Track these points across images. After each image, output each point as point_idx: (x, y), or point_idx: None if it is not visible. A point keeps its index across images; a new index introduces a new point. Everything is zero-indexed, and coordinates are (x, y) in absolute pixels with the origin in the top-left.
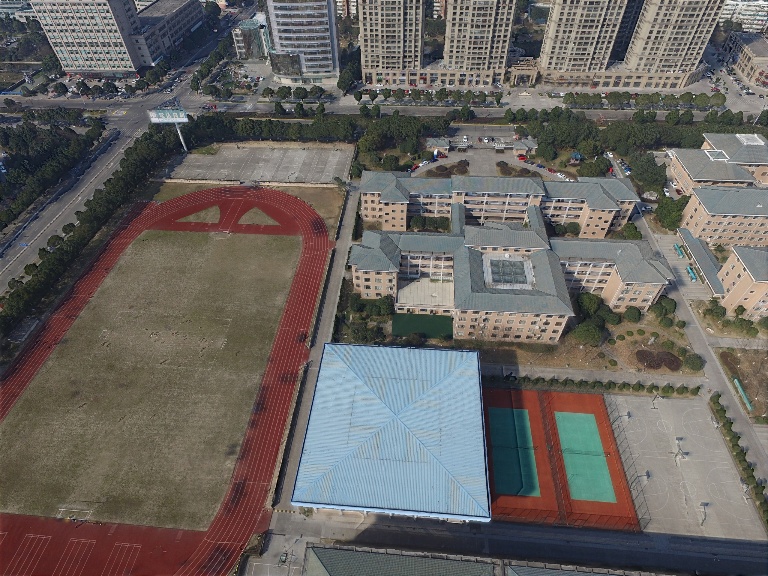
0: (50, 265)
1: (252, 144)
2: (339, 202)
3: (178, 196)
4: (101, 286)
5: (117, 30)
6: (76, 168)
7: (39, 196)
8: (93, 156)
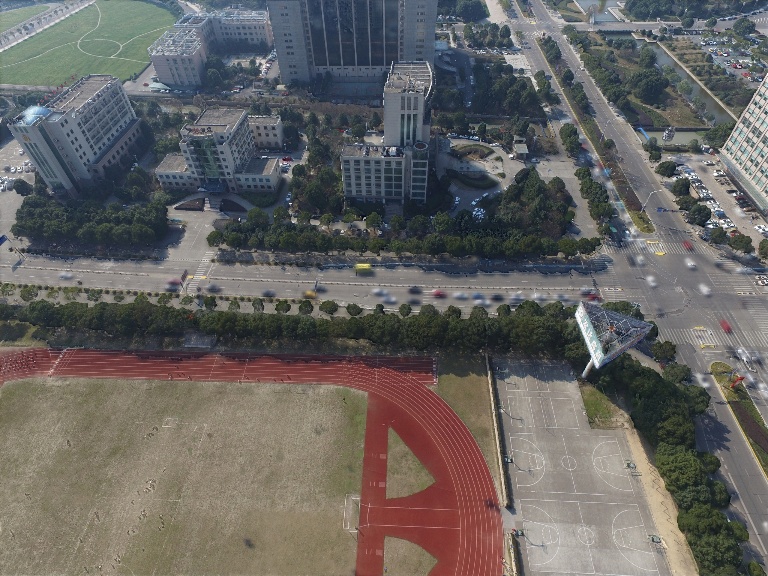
0: (268, 325)
1: (655, 490)
2: None
3: (453, 408)
4: (258, 384)
5: None
6: (492, 261)
7: None
8: (530, 265)
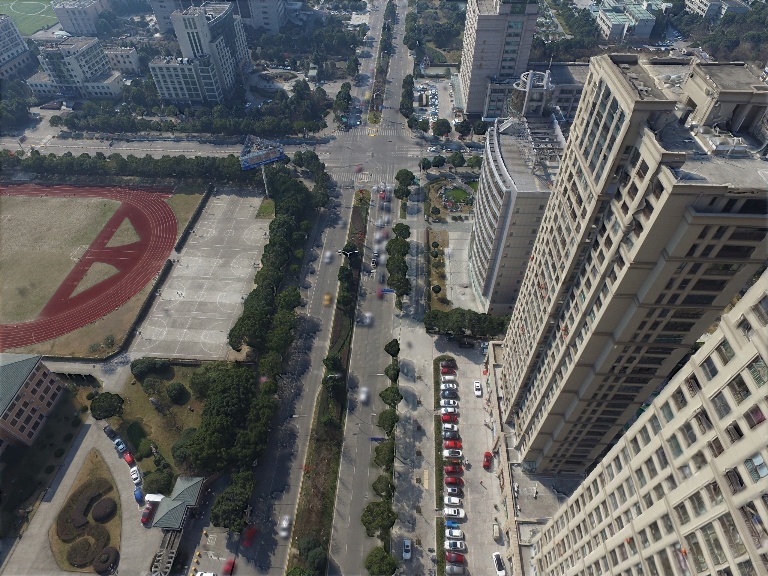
0: (64, 162)
1: None
2: (84, 352)
3: (173, 209)
4: (52, 198)
5: (472, 64)
6: None
7: (209, 133)
8: None
